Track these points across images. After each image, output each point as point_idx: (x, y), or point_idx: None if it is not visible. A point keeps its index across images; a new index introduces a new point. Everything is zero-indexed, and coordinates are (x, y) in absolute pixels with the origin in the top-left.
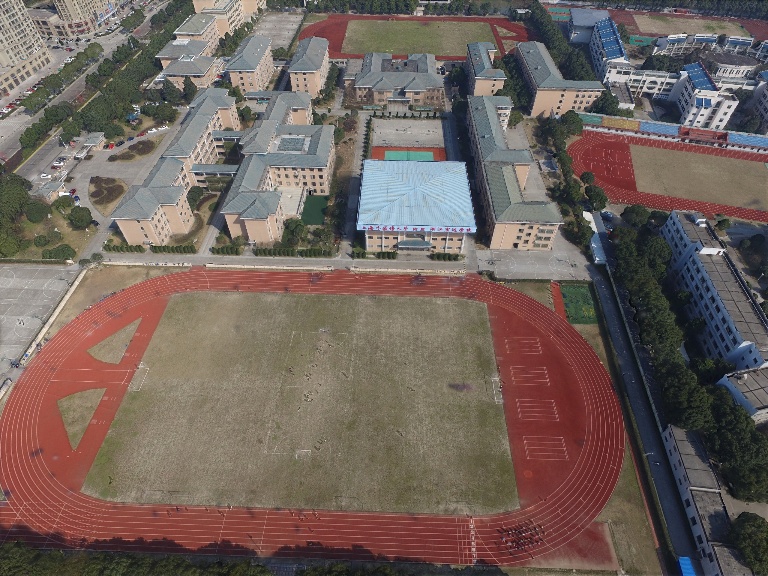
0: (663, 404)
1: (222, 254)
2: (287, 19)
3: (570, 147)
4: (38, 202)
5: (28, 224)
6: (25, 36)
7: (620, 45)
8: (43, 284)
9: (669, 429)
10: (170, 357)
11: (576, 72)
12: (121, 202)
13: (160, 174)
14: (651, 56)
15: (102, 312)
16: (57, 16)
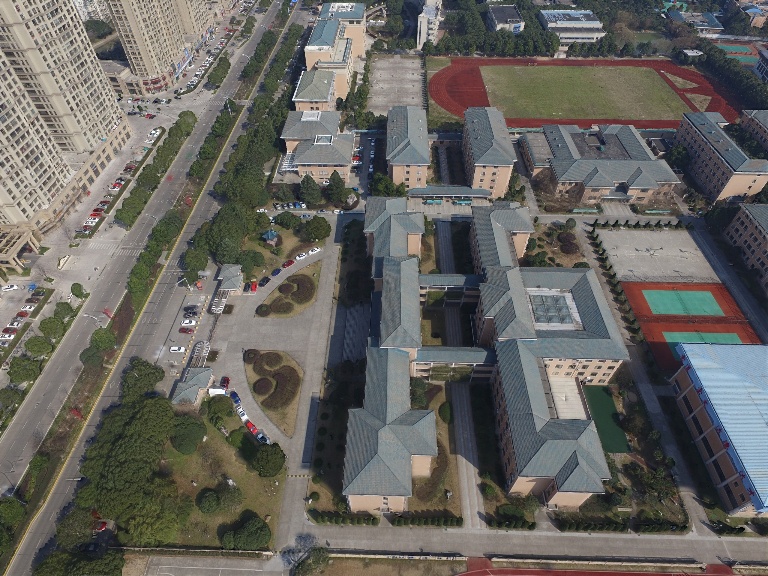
0: None
1: (504, 527)
2: (403, 65)
3: None
4: (189, 420)
5: (175, 456)
6: (104, 109)
7: None
8: None
9: None
10: None
11: None
12: (350, 455)
13: (391, 389)
14: None
15: None
16: (128, 70)
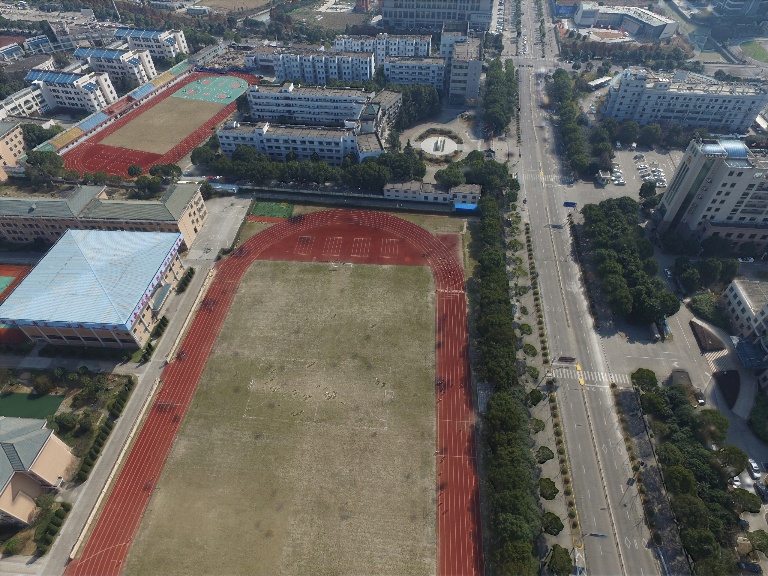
0: (371, 186)
1: (54, 537)
2: None
3: None
4: None
5: None
6: None
7: None
8: None
9: (385, 190)
10: (245, 570)
11: None
12: None
13: None
14: None
15: None
16: None
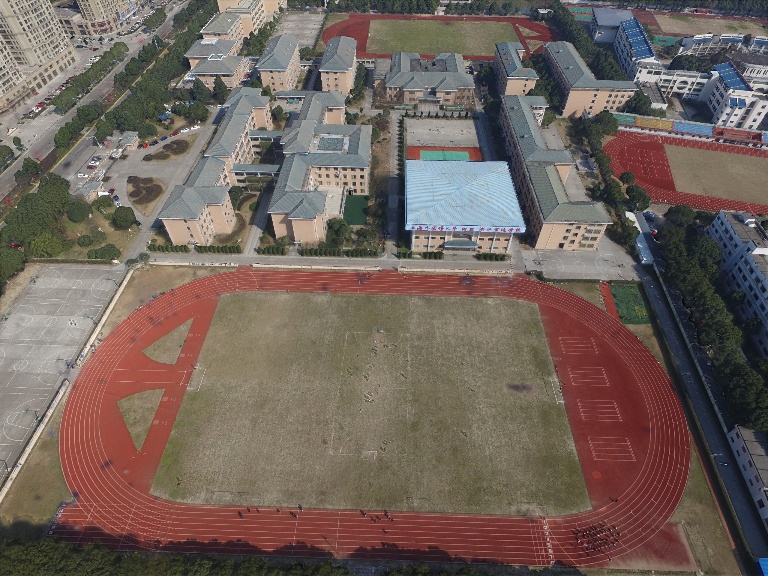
0: (728, 405)
1: (267, 254)
2: (308, 18)
3: (605, 147)
4: (79, 202)
5: (70, 224)
6: (52, 35)
7: (649, 45)
8: (91, 284)
9: (736, 430)
10: (226, 357)
11: (605, 72)
12: (167, 202)
13: (204, 174)
14: (680, 56)
15: (153, 312)
16: (80, 15)
